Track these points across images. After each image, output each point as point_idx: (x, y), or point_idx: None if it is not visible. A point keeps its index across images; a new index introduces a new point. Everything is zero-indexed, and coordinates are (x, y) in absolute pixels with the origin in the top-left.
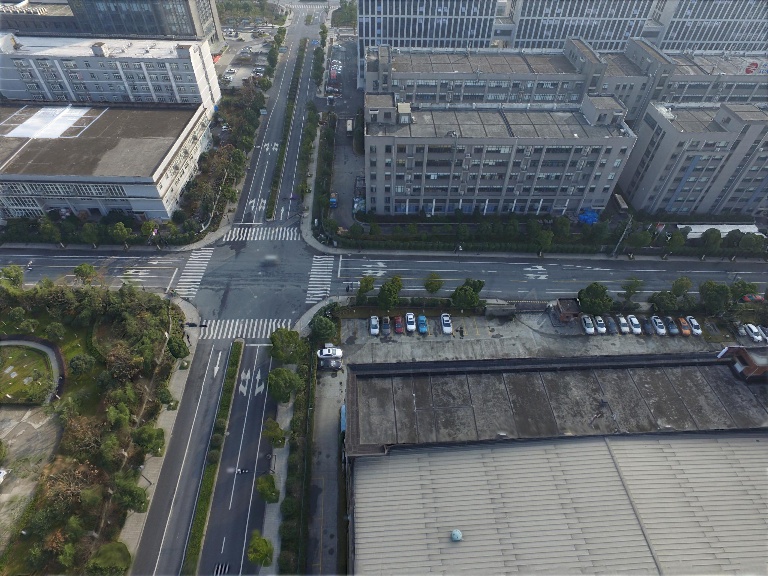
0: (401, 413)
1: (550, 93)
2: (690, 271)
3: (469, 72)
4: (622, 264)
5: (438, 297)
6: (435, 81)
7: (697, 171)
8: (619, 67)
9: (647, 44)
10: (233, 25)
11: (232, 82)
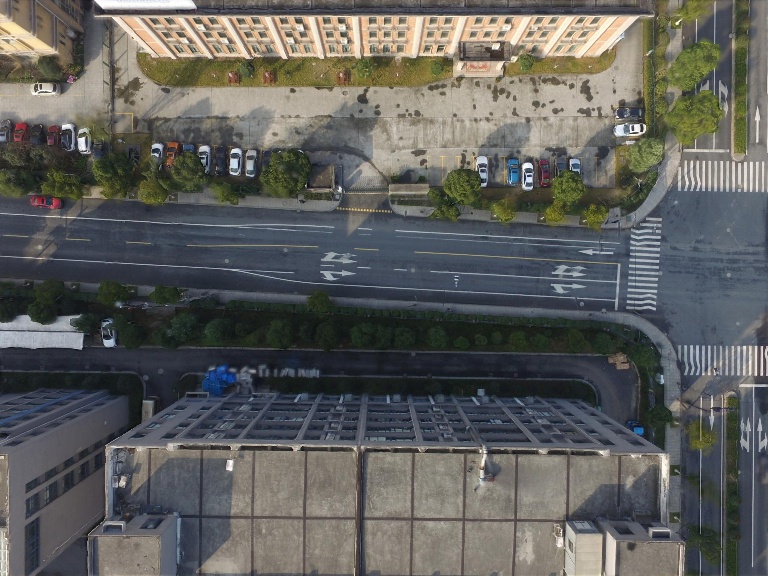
0: None
1: None
2: (107, 262)
3: None
4: (203, 280)
5: (485, 221)
6: None
7: (2, 417)
8: None
9: None
10: None
11: None
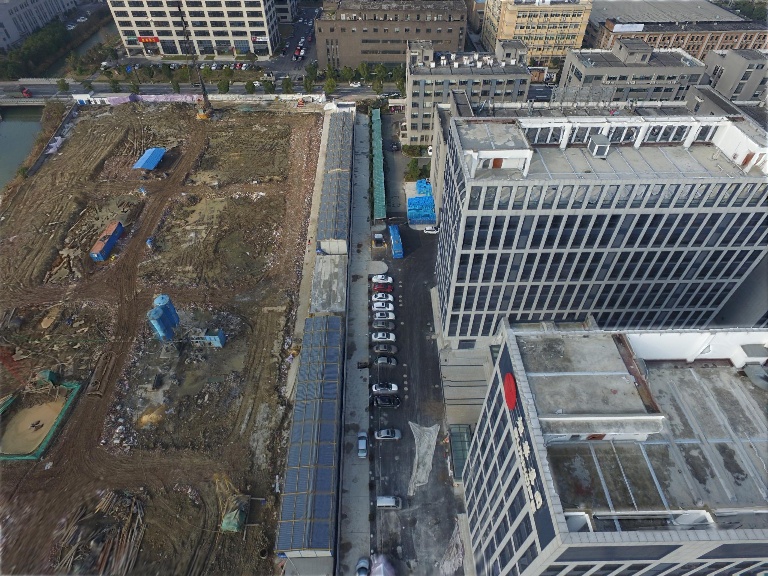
0: (752, 27)
1: None
2: None
3: None
4: None
5: None
6: None
7: None
8: None
9: None
10: None
11: None
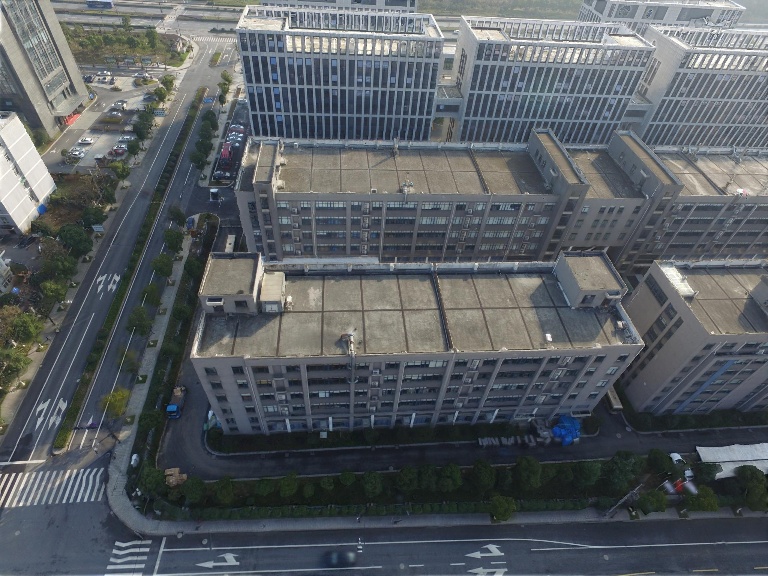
0: None
1: (509, 216)
2: (723, 543)
3: (393, 187)
4: (621, 531)
5: None
6: (342, 202)
7: (727, 374)
8: (602, 177)
9: (638, 143)
10: (108, 68)
11: (83, 159)
